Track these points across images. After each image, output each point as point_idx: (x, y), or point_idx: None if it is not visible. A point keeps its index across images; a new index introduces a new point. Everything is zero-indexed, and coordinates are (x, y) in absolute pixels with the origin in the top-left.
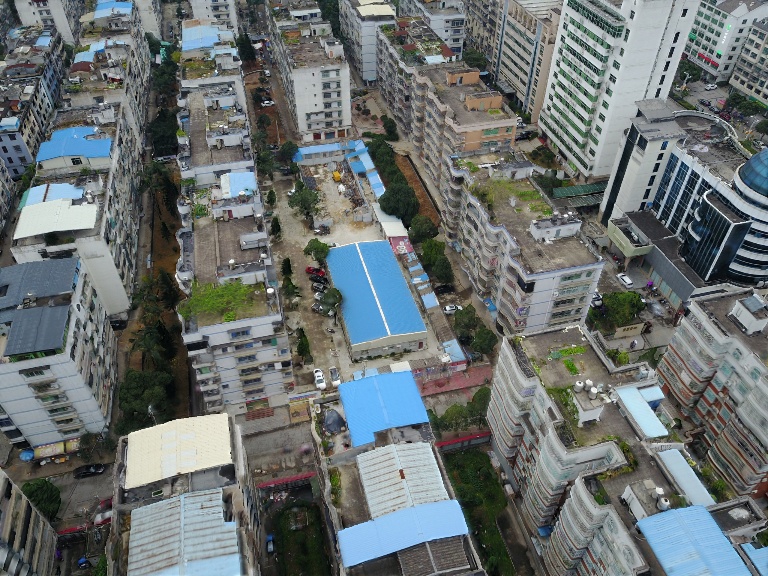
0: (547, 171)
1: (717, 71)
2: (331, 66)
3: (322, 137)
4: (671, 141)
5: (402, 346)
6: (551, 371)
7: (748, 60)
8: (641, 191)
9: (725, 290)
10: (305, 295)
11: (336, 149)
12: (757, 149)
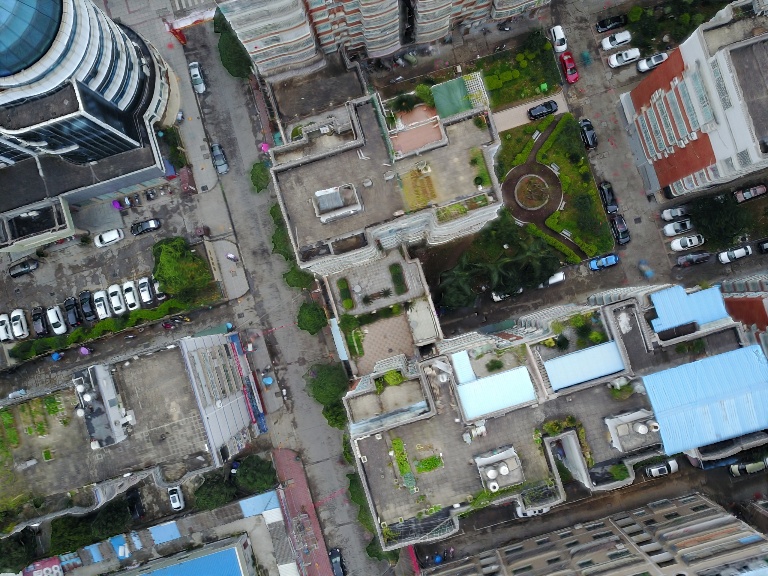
0: None
1: None
2: None
3: None
4: None
5: (252, 574)
6: (436, 491)
7: None
8: None
9: (150, 118)
10: None
11: None
12: None
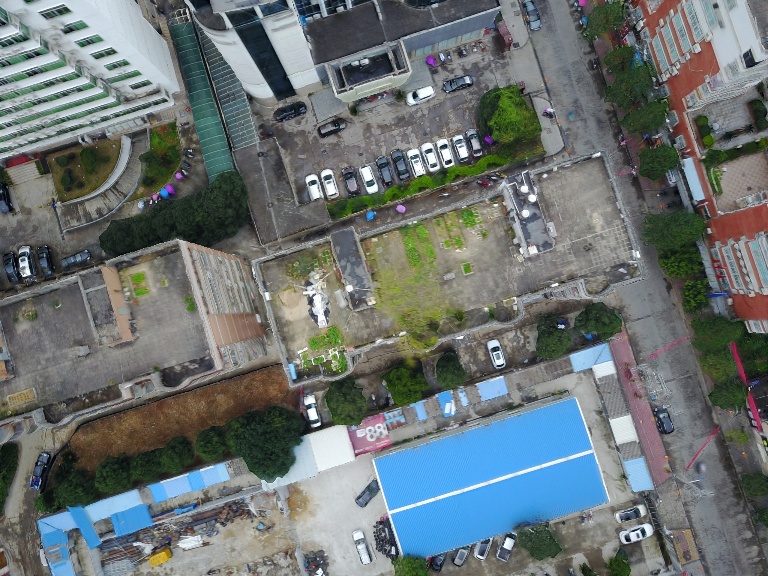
0: (147, 170)
1: None
2: None
3: None
4: None
5: None
6: None
7: None
8: None
9: None
10: (473, 573)
11: (70, 569)
12: None
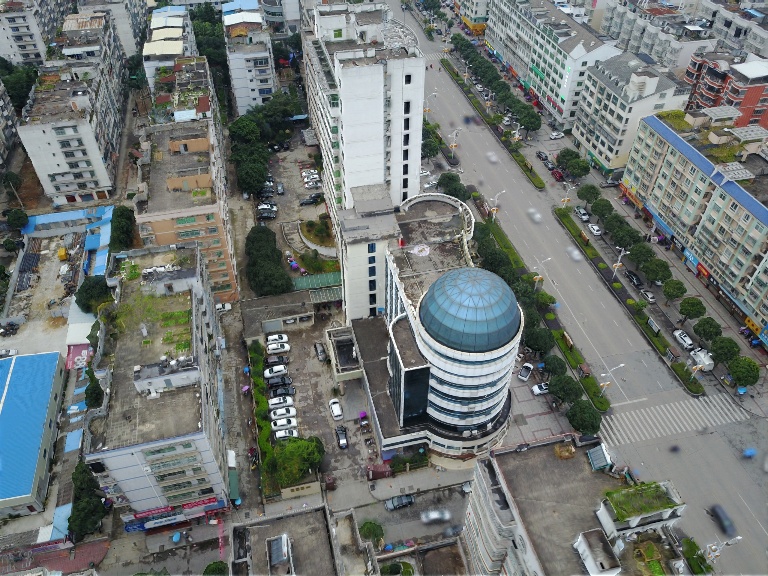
0: (306, 251)
1: (562, 118)
2: (65, 122)
3: (78, 199)
4: (378, 243)
5: (2, 512)
6: None
7: (585, 109)
8: (363, 297)
9: (428, 438)
10: None
11: (79, 217)
12: (578, 219)
